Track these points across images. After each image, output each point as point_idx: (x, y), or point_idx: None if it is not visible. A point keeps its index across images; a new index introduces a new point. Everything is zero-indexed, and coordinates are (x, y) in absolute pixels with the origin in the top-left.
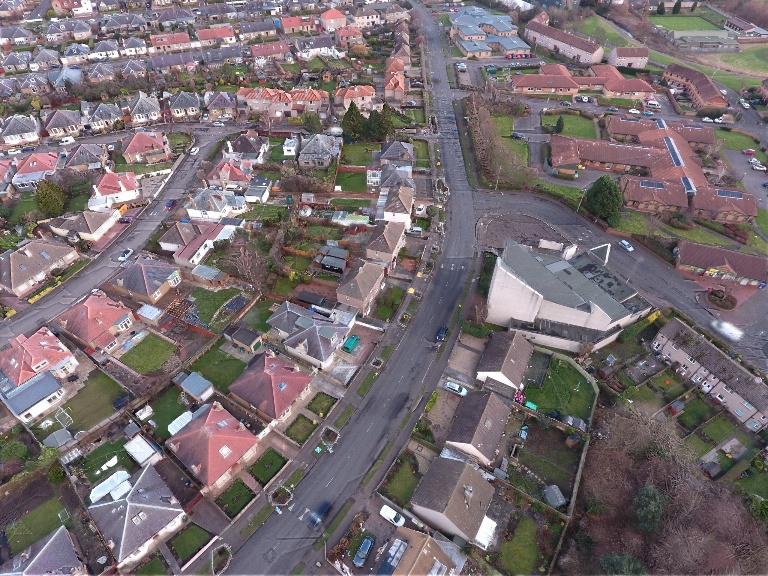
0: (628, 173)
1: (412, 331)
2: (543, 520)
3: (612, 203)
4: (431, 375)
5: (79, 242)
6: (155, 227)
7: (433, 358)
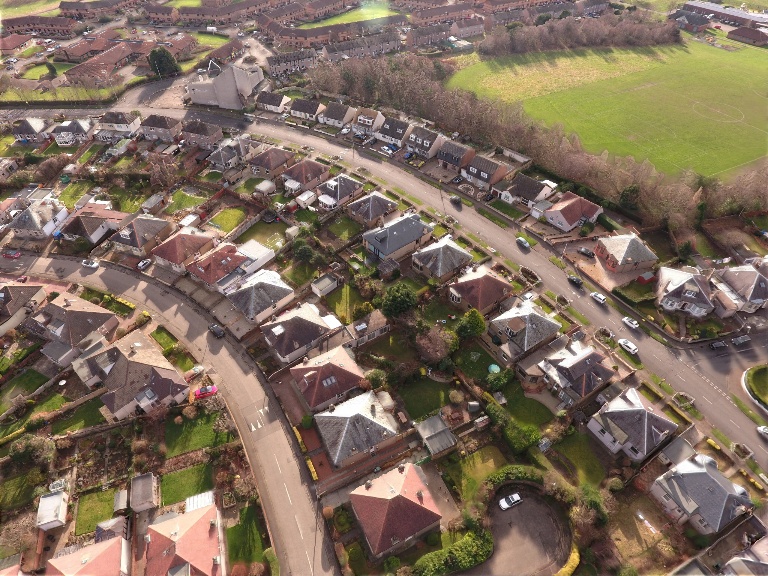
0: (131, 62)
1: (242, 129)
2: (349, 105)
3: (172, 58)
4: (275, 124)
5: (51, 295)
6: (48, 259)
7: (264, 123)
